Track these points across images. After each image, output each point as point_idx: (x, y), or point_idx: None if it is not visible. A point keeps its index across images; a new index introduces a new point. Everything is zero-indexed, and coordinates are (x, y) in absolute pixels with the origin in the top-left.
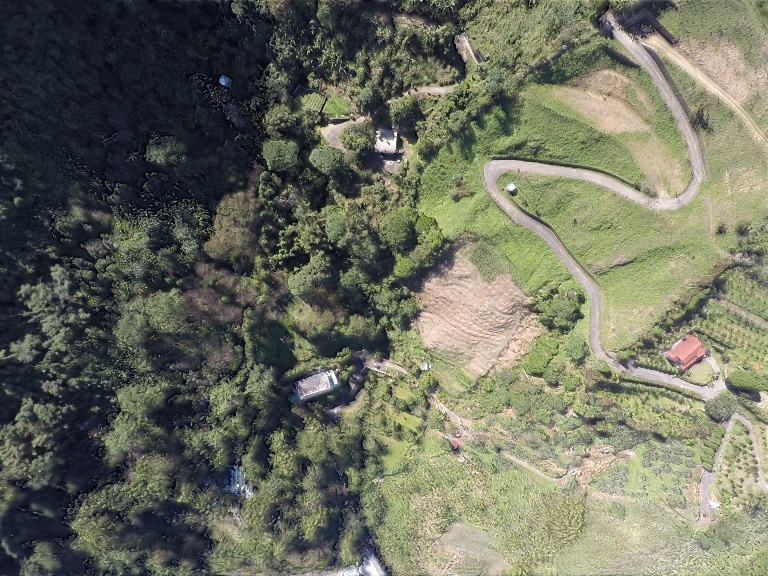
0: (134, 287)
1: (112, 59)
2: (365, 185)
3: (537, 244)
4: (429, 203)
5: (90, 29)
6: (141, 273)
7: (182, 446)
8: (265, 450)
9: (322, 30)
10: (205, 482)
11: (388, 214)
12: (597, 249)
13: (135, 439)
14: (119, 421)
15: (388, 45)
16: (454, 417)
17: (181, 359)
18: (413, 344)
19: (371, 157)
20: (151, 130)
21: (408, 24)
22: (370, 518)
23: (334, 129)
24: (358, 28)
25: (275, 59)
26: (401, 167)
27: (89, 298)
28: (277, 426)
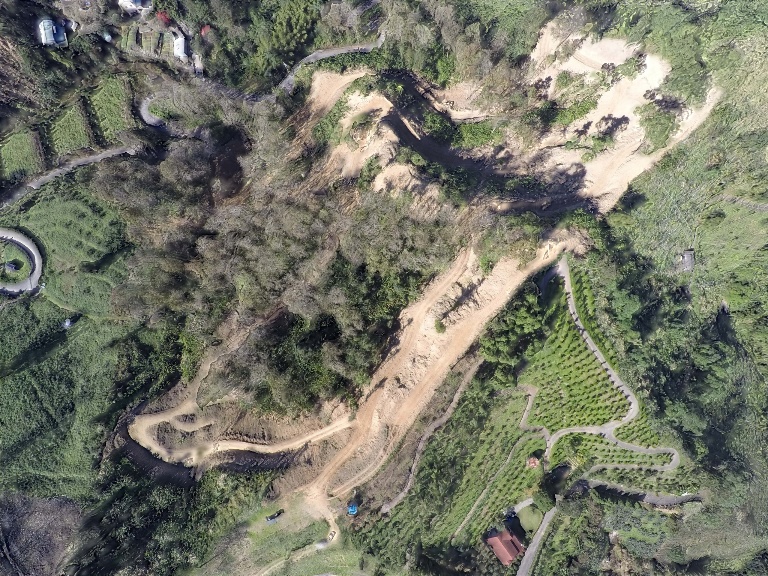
0: None
1: None
2: None
3: None
4: None
5: None
6: None
7: None
8: None
9: None
10: None
11: None
12: None
13: None
14: None
15: None
16: None
17: None
18: None
19: None
20: None
21: None
22: None
23: None
24: None
25: None
26: None
27: None
28: None
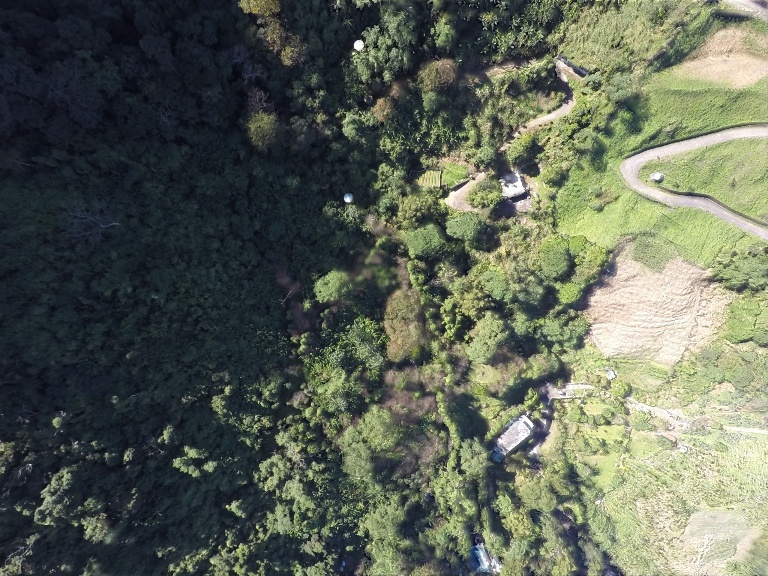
0: (344, 421)
1: (260, 227)
2: (502, 233)
3: (699, 217)
4: (569, 223)
5: (234, 210)
6: (346, 405)
7: (432, 549)
8: (496, 518)
9: (427, 114)
10: (459, 573)
11: (533, 250)
12: (766, 197)
13: (397, 562)
14: (376, 551)
15: (489, 100)
16: (659, 411)
17: (399, 467)
18: (592, 359)
19: (501, 205)
20: (311, 273)
21: (503, 73)
22: (606, 541)
23: (457, 195)
24: (459, 98)
25: (388, 159)
26: (534, 202)
27: (310, 448)
28: (495, 490)
